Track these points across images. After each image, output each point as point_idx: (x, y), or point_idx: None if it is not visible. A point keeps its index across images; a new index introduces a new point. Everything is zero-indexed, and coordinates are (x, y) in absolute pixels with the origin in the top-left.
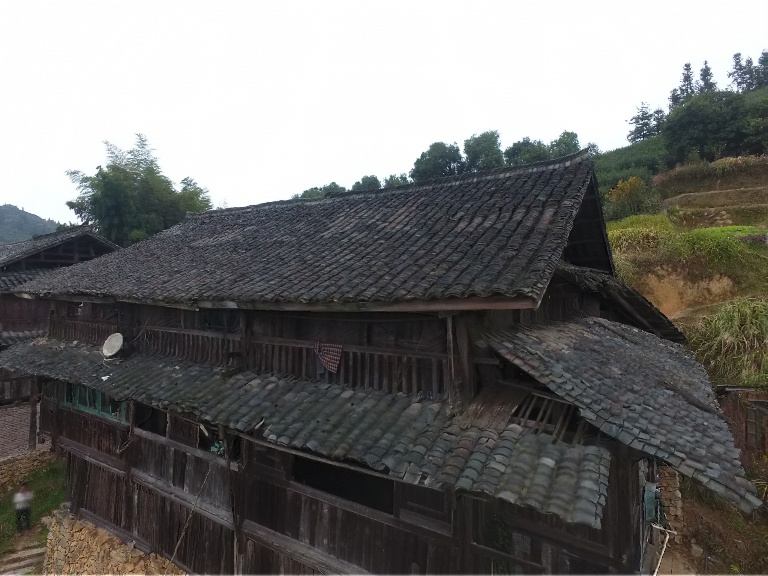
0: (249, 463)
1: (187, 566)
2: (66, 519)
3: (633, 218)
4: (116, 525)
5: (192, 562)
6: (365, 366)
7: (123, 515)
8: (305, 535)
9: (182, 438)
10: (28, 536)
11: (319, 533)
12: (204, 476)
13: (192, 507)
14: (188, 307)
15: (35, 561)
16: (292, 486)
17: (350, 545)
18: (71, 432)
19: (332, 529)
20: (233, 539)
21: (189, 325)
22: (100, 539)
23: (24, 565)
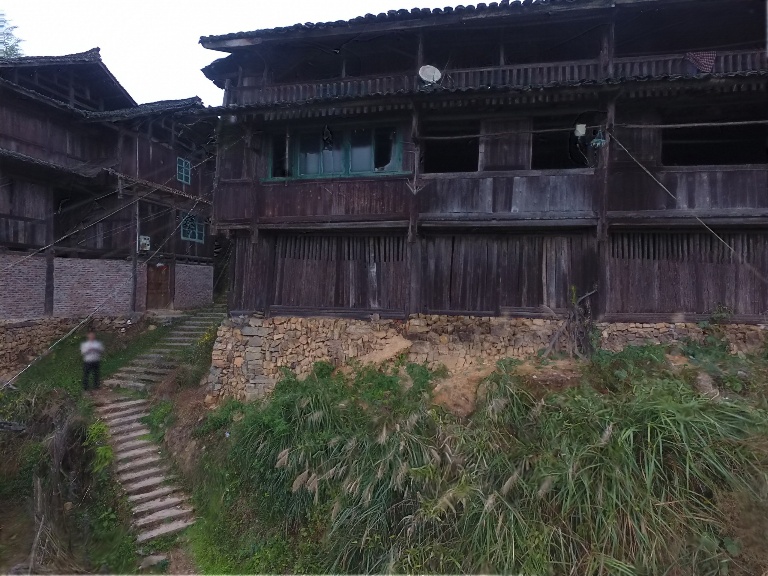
0: (610, 163)
1: (469, 310)
2: (253, 318)
3: None
4: (341, 306)
5: (478, 303)
6: (738, 64)
7: (352, 293)
8: (684, 202)
9: (507, 165)
10: (103, 394)
11: (699, 196)
12: (544, 190)
13: (527, 223)
14: (600, 5)
15: (142, 409)
16: (665, 169)
17: (733, 195)
18: (285, 207)
19: (714, 189)
20: (541, 263)
21: (510, 62)
22: (327, 320)
23: (131, 412)
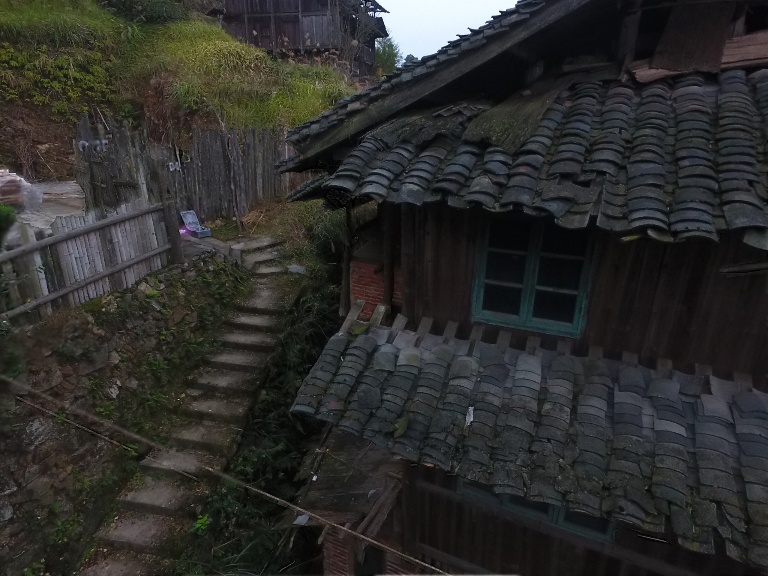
0: None
1: None
2: None
3: (199, 25)
4: None
5: None
6: None
7: None
8: None
9: None
10: None
11: None
12: None
13: None
14: None
15: None
16: None
17: None
18: None
19: None
20: None
21: None
22: None
23: None
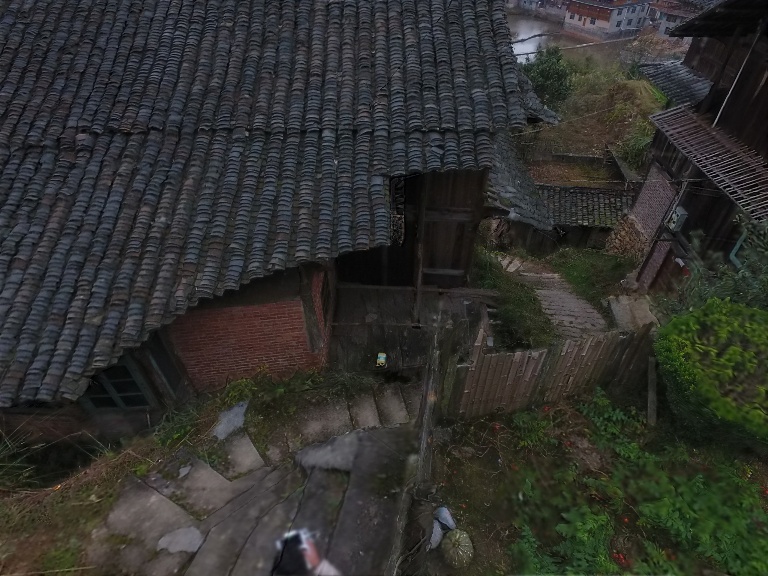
0: None
1: None
2: None
3: None
4: None
5: None
6: None
7: None
8: None
9: None
10: (539, 268)
11: None
12: None
13: None
14: None
15: None
16: None
17: None
18: None
19: None
20: None
21: None
22: None
23: None
